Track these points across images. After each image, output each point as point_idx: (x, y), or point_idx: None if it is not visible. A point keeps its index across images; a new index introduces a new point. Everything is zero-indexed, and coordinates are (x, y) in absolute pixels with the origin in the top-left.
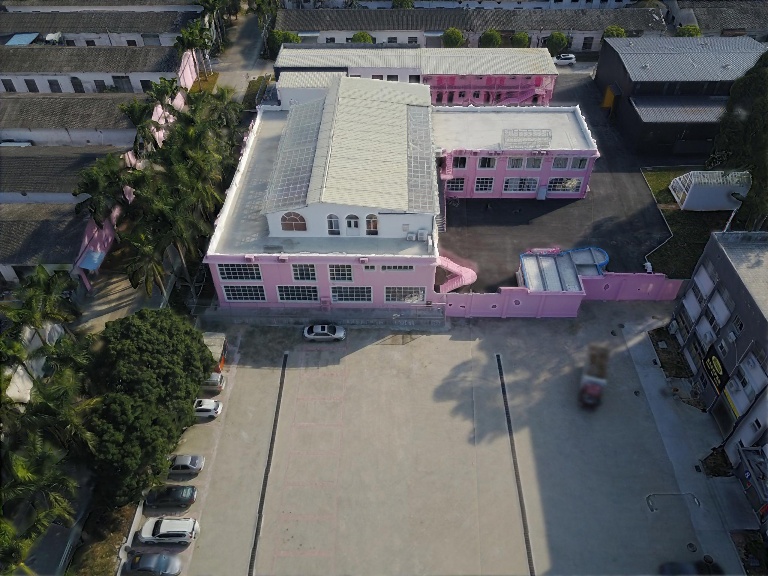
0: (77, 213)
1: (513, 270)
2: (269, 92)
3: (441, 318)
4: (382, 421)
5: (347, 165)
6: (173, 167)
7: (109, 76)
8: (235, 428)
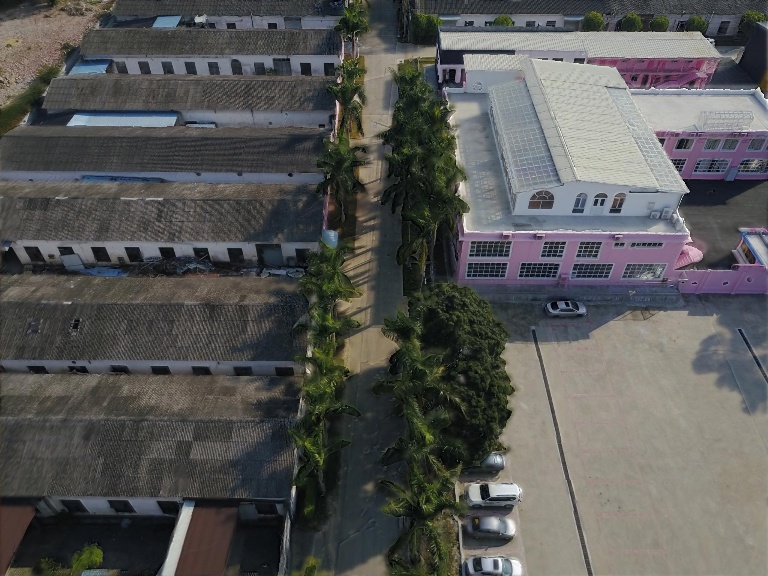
0: (317, 192)
1: (728, 248)
2: (423, 75)
3: (677, 294)
4: (653, 392)
5: (583, 145)
6: (428, 146)
7: (270, 59)
8: (512, 399)
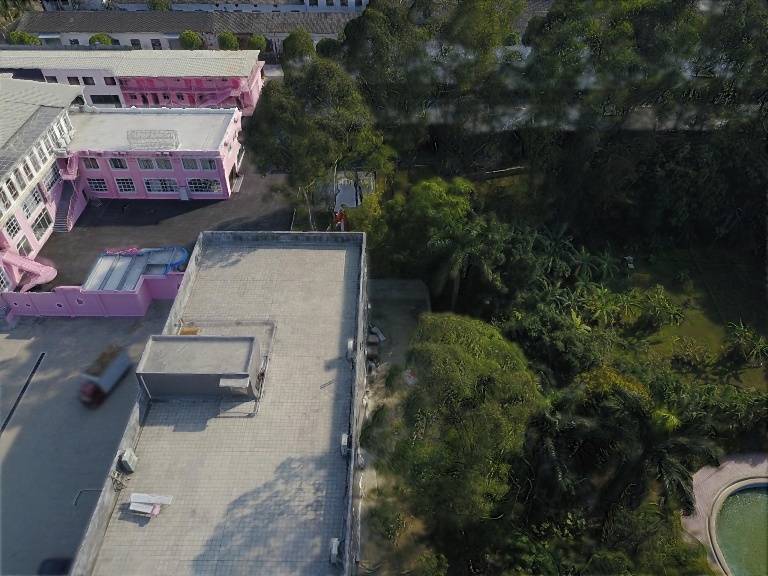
0: None
1: None
2: None
3: (2, 317)
4: None
5: None
6: None
7: None
8: None
